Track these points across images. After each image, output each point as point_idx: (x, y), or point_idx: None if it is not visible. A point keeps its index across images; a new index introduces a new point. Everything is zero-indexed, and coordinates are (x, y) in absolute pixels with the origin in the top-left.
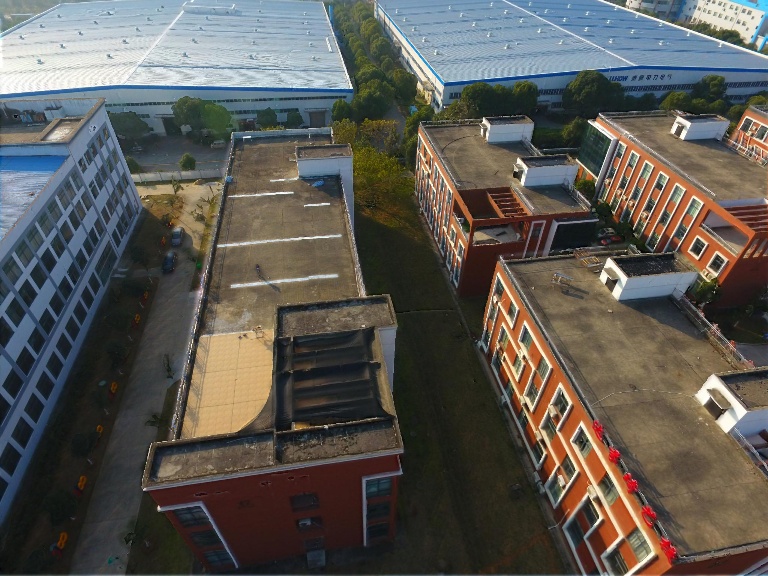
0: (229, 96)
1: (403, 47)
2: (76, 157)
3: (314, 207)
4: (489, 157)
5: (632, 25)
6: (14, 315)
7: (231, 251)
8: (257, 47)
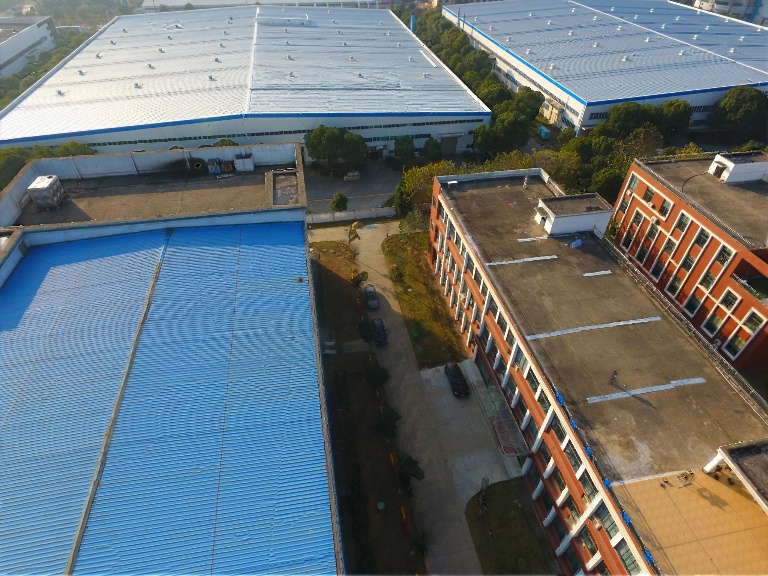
0: (361, 123)
1: (500, 59)
2: None
3: (597, 277)
4: (744, 203)
5: (731, 31)
6: None
7: (548, 345)
8: (357, 63)
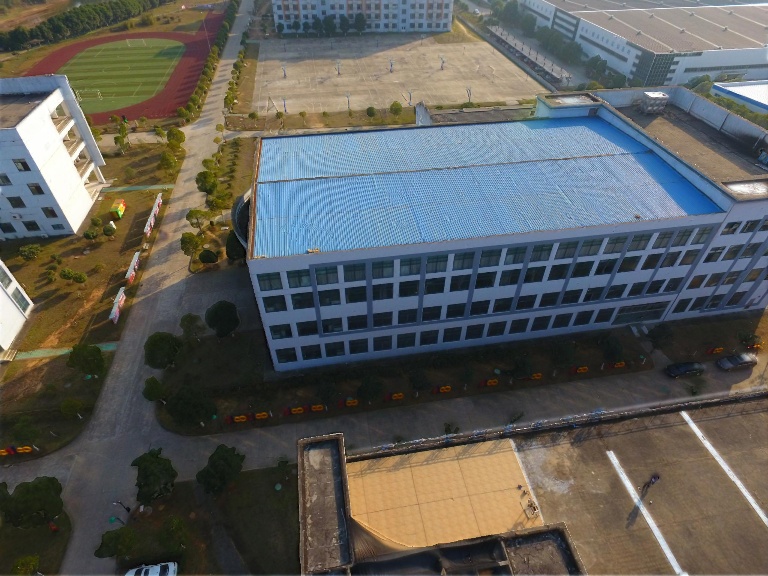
0: None
1: None
2: (733, 218)
3: None
4: None
5: None
6: (507, 278)
7: (682, 432)
8: None
